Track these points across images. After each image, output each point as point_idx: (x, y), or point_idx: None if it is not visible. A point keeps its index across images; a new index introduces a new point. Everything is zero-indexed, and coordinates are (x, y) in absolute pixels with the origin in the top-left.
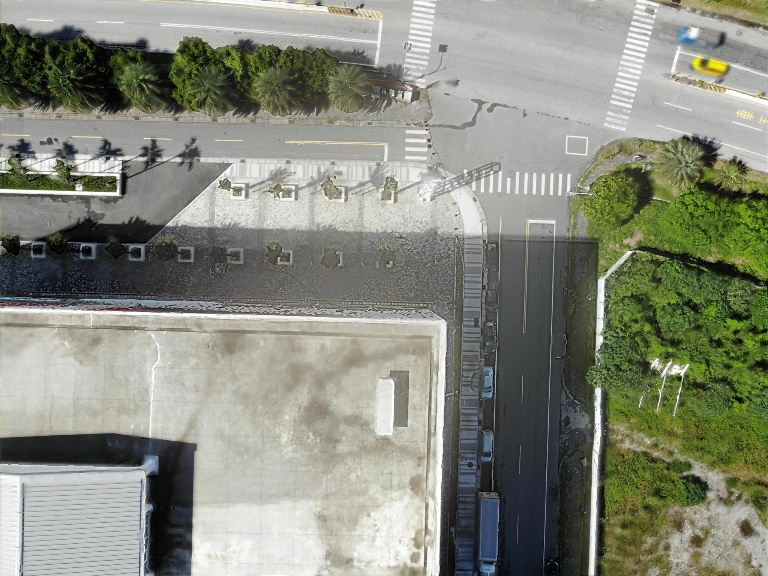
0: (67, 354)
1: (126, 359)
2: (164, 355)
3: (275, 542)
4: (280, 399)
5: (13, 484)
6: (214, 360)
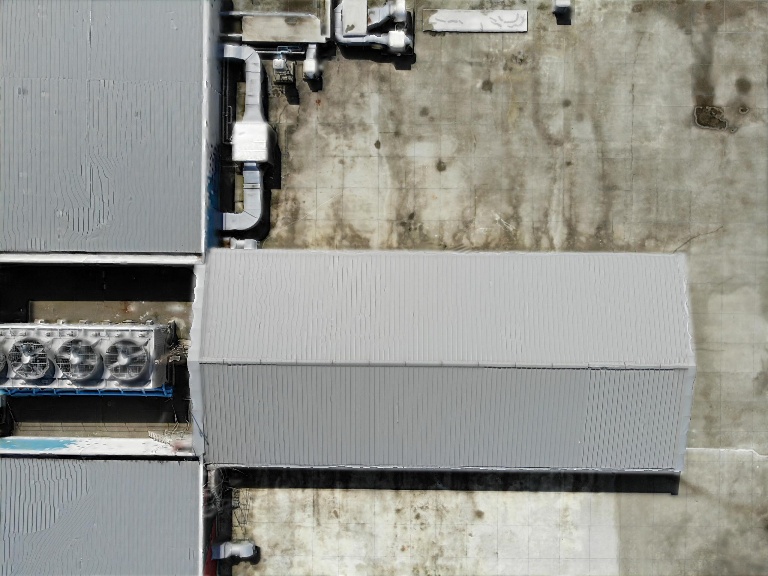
0: (765, 364)
1: (761, 423)
2: (765, 461)
3: (581, 573)
4: (723, 575)
5: (687, 358)
6: (761, 510)
